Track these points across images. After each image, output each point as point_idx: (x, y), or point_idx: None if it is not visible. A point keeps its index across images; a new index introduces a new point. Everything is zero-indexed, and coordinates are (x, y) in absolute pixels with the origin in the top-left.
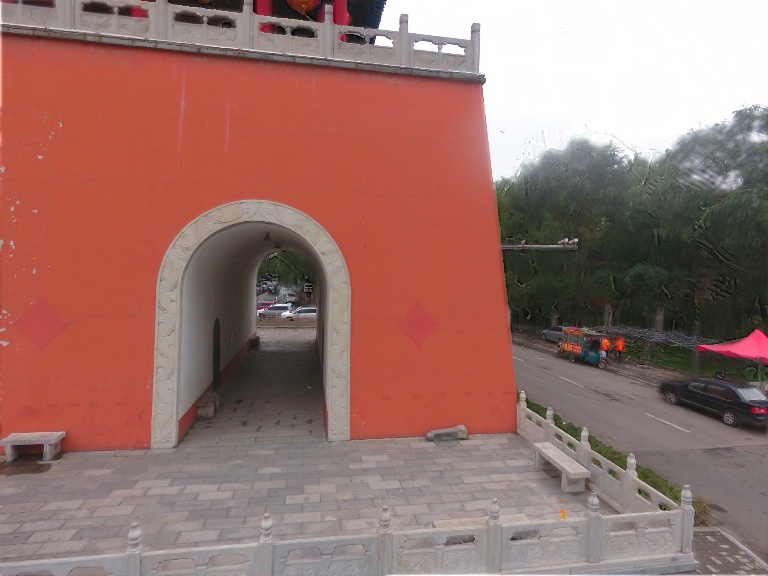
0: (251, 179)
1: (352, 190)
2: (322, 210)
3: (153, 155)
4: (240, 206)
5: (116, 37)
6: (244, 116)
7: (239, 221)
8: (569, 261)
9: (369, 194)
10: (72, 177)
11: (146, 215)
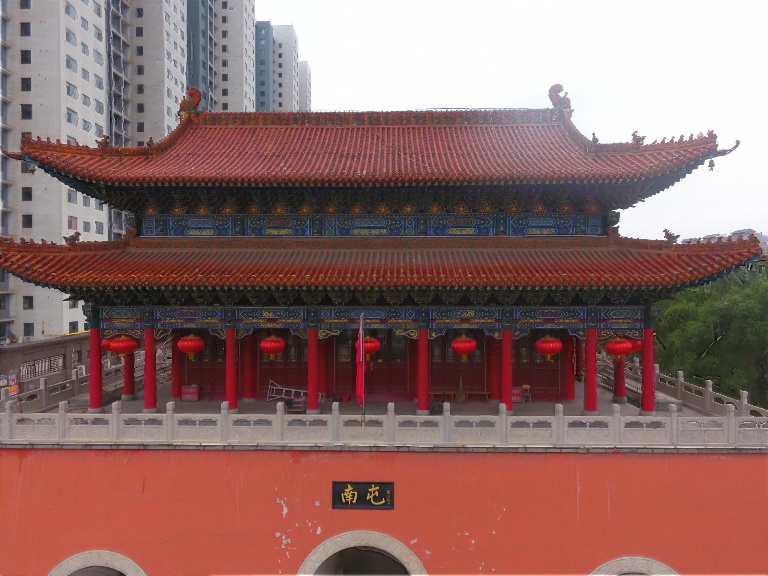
0: (627, 540)
1: (700, 546)
2: (678, 562)
3: (561, 527)
4: (621, 562)
5: (535, 447)
6: (619, 494)
7: (621, 573)
8: (764, 401)
9: (713, 549)
10: (513, 545)
11: (560, 569)
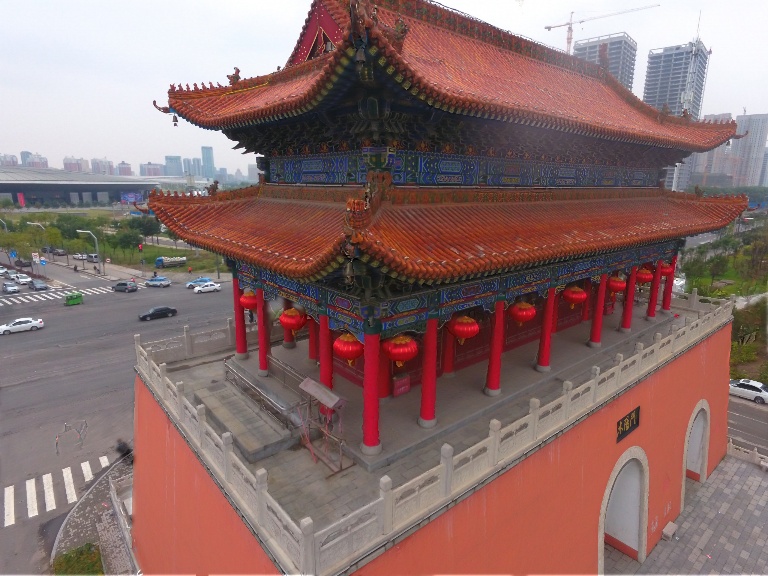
0: None
1: None
2: None
3: None
4: None
5: None
6: None
7: None
8: None
9: None
10: None
11: None
